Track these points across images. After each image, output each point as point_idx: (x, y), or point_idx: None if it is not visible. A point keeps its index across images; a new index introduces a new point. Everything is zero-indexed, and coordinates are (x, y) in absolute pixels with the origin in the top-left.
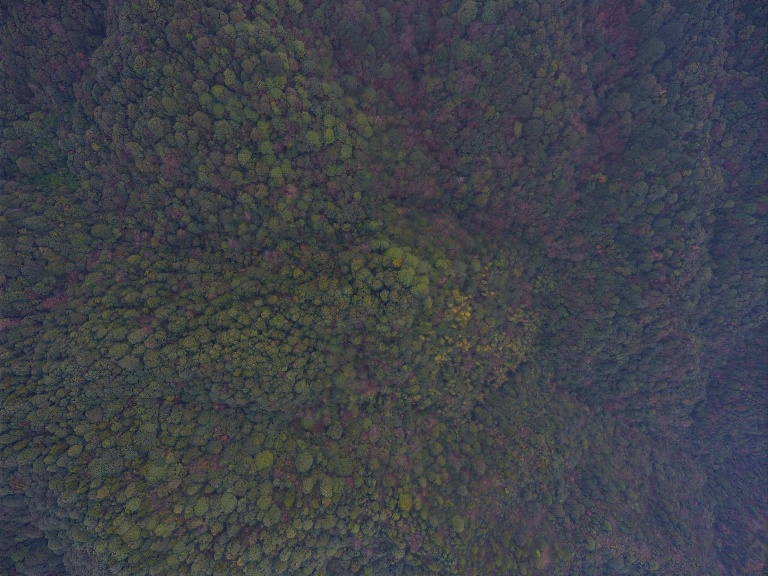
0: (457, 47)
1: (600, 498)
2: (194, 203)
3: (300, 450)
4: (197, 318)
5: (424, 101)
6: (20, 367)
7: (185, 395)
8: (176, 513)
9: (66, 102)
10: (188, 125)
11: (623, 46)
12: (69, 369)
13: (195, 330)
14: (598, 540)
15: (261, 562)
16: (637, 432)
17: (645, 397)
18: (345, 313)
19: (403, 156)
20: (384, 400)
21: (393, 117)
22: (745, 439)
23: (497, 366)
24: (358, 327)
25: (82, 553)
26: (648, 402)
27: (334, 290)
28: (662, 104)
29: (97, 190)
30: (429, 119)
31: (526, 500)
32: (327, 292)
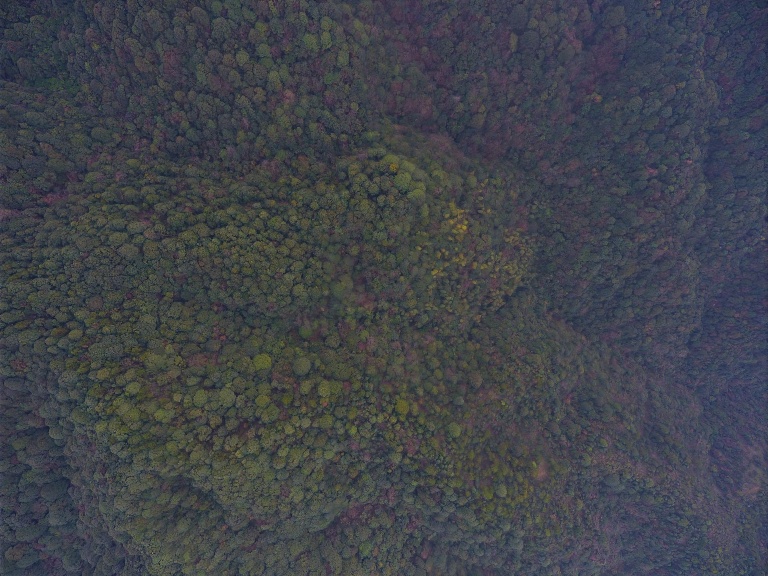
0: None
1: (596, 418)
2: (193, 107)
3: (298, 356)
4: (196, 215)
5: (420, 16)
6: (21, 252)
7: (184, 292)
8: (175, 400)
9: (66, 5)
10: (187, 20)
11: None
12: (69, 253)
13: (194, 225)
14: (594, 457)
15: (259, 456)
16: (633, 362)
17: (641, 324)
18: (342, 218)
19: (400, 71)
20: (381, 315)
21: (390, 32)
22: (740, 369)
23: (494, 288)
24: (355, 236)
25: (82, 438)
26: (644, 329)
27: (331, 194)
28: (656, 16)
29: (97, 94)
30: (425, 35)
31: (522, 415)
32: (324, 195)
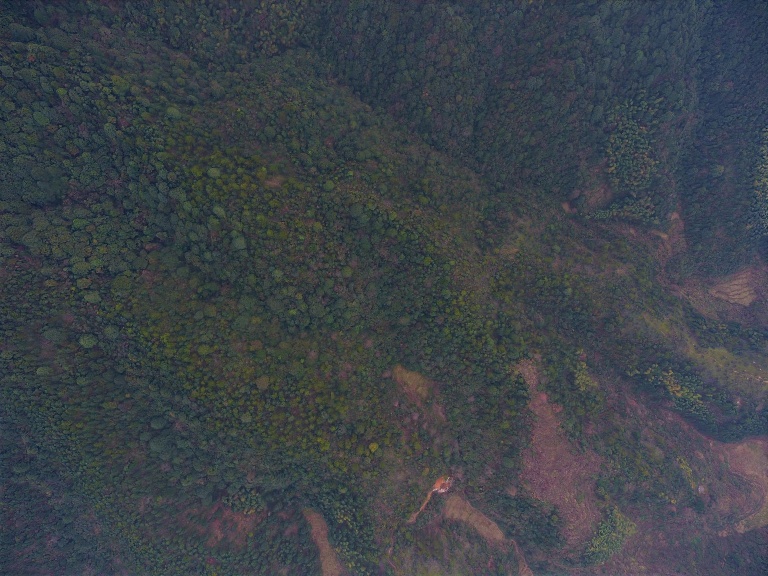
0: None
1: (351, 157)
2: None
3: None
4: None
5: None
6: None
7: None
8: None
9: None
10: None
11: None
12: None
13: None
14: (338, 185)
15: None
16: (419, 138)
17: (419, 90)
18: None
19: None
20: None
21: None
22: (524, 153)
23: (262, 28)
24: None
25: None
26: (422, 95)
27: None
28: None
29: None
30: None
31: (266, 134)
32: None
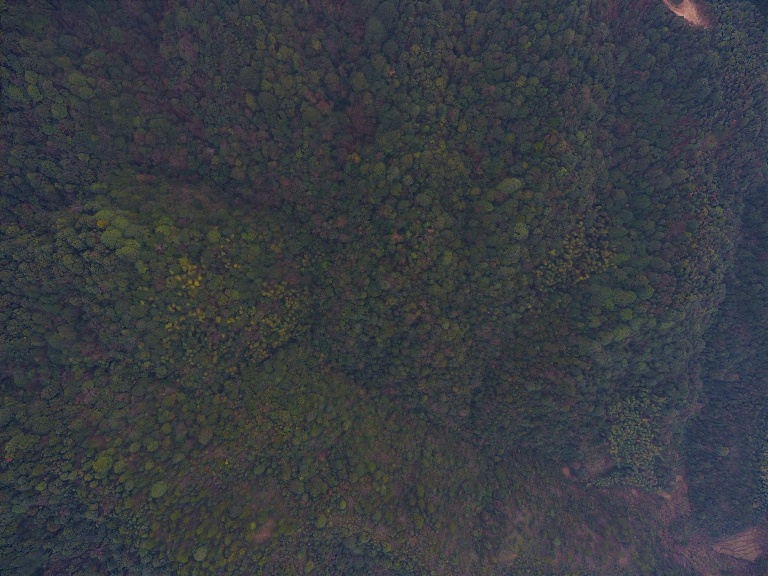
0: (178, 14)
1: (344, 478)
2: None
3: (3, 406)
4: None
5: (166, 69)
6: None
7: None
8: None
9: None
10: None
11: (351, 24)
12: None
13: None
14: (331, 518)
15: None
16: (414, 418)
17: (414, 383)
18: (49, 271)
19: (142, 122)
20: (116, 365)
21: (133, 83)
22: (523, 432)
23: (252, 341)
24: (73, 288)
25: None
26: (417, 388)
27: (34, 247)
28: (395, 85)
29: None
30: (172, 87)
31: (255, 474)
32: (26, 248)
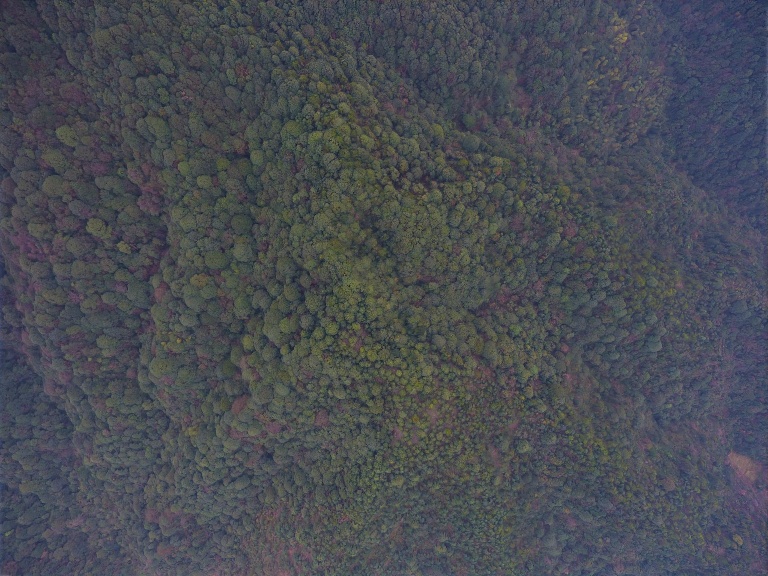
0: None
1: (724, 251)
2: None
3: None
4: None
5: None
6: None
7: (379, 45)
8: (377, 130)
9: None
10: None
11: None
12: None
13: None
14: (724, 282)
15: (441, 205)
16: (747, 221)
17: (763, 177)
18: (522, 3)
19: None
20: (534, 123)
21: None
22: None
23: None
24: (527, 29)
25: (290, 155)
26: (766, 183)
27: None
28: None
29: None
30: None
31: (661, 232)
32: None
